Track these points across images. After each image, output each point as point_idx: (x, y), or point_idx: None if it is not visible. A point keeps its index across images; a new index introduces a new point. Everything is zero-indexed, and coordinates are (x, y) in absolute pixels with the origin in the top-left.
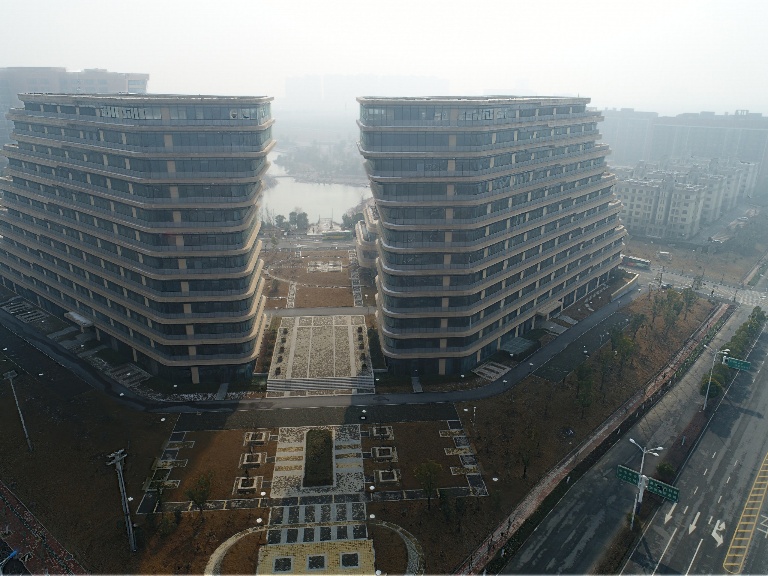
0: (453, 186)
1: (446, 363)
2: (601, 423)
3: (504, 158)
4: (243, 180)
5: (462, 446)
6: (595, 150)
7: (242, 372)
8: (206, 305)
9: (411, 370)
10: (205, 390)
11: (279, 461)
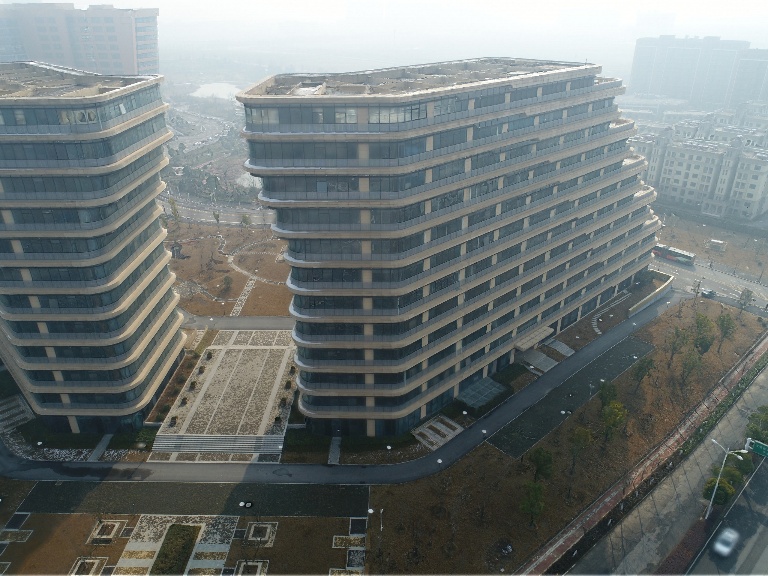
0: (369, 212)
1: (376, 423)
2: (556, 534)
3: (451, 167)
4: (88, 203)
5: (354, 567)
6: (611, 132)
7: (129, 422)
8: (72, 349)
9: (332, 429)
10: (81, 445)
11: (116, 575)
